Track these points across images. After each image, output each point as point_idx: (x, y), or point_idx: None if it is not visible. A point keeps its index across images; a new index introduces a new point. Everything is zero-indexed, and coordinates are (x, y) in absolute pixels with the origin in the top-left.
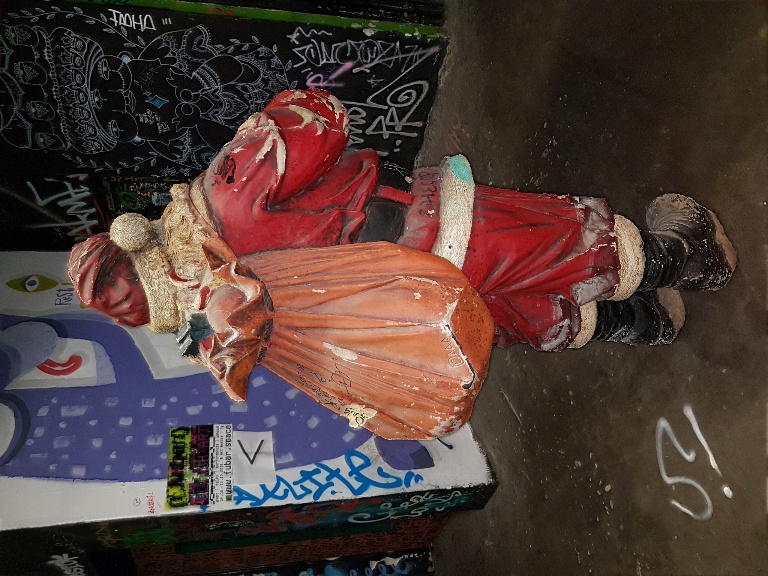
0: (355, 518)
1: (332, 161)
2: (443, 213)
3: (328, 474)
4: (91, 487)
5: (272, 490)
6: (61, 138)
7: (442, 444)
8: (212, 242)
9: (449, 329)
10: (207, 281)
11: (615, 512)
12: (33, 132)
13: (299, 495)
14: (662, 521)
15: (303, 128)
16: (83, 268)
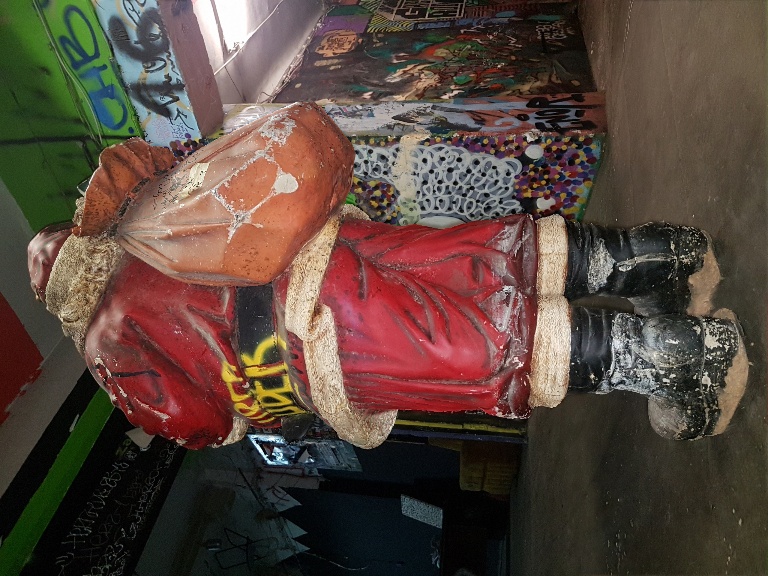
0: None
1: None
2: None
3: None
4: None
5: None
6: None
7: None
8: None
9: None
10: None
11: None
12: None
13: None
14: None
15: None
16: None
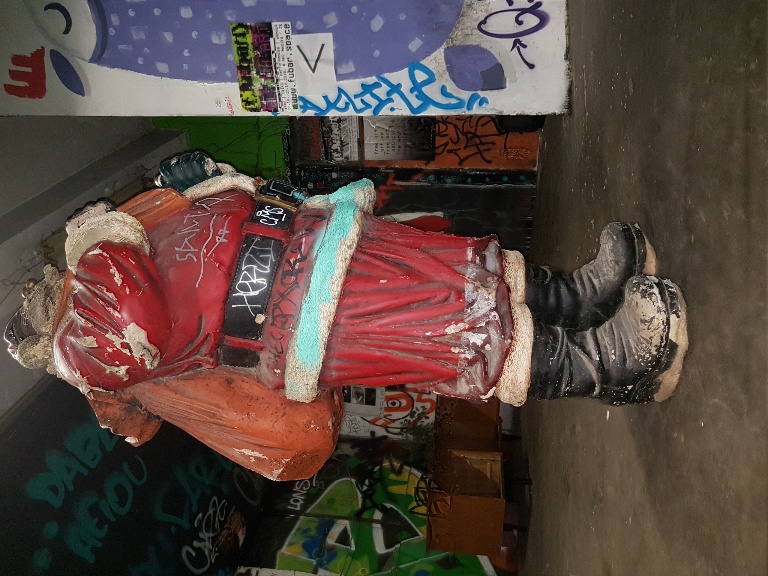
0: None
1: None
2: (285, 383)
3: (389, 89)
4: (178, 86)
5: (334, 102)
6: None
7: (523, 62)
8: (92, 398)
9: None
10: None
11: None
12: None
13: (359, 109)
14: None
15: (109, 374)
16: None
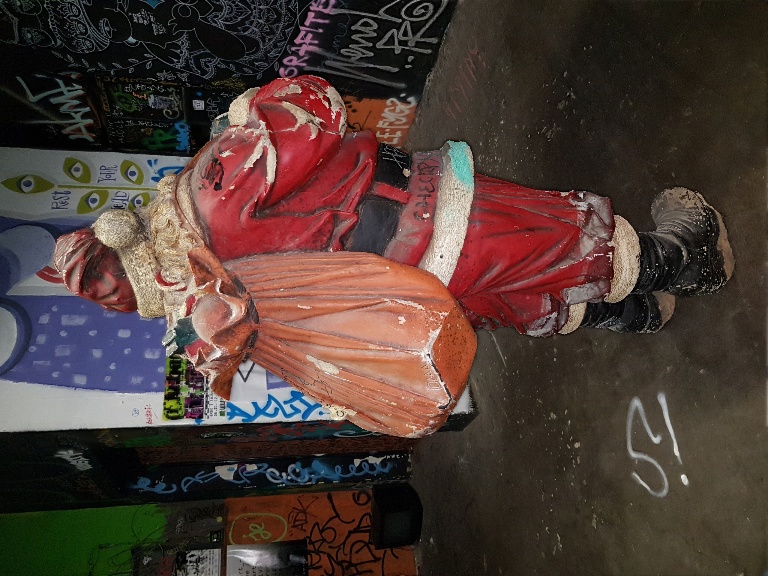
0: (341, 433)
1: (326, 163)
2: (438, 220)
3: None
4: (92, 396)
5: (263, 408)
6: (50, 34)
7: None
8: (198, 251)
9: (430, 358)
10: (193, 289)
11: (581, 467)
12: (19, 27)
13: (289, 414)
14: (621, 487)
15: (296, 131)
16: (69, 264)
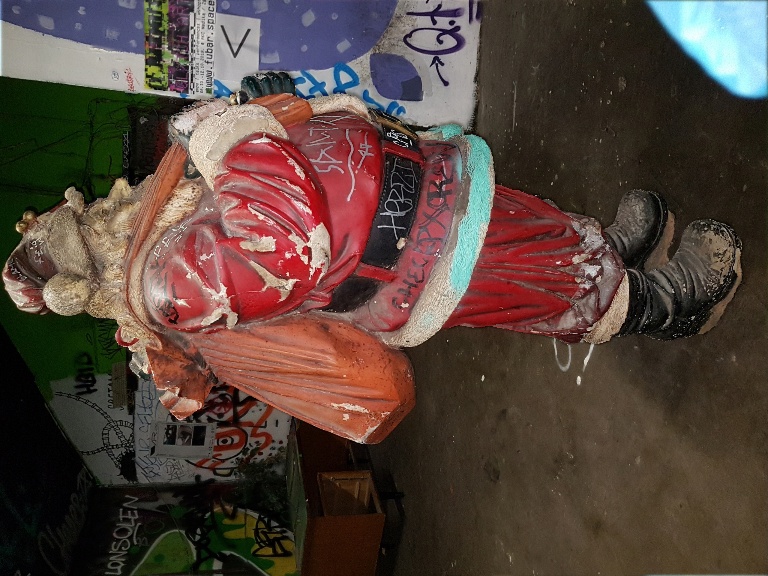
0: None
1: None
2: (414, 318)
3: (313, 86)
4: (64, 47)
5: None
6: None
7: (439, 78)
8: None
9: None
10: None
11: None
12: None
13: None
14: None
15: (263, 293)
16: None
